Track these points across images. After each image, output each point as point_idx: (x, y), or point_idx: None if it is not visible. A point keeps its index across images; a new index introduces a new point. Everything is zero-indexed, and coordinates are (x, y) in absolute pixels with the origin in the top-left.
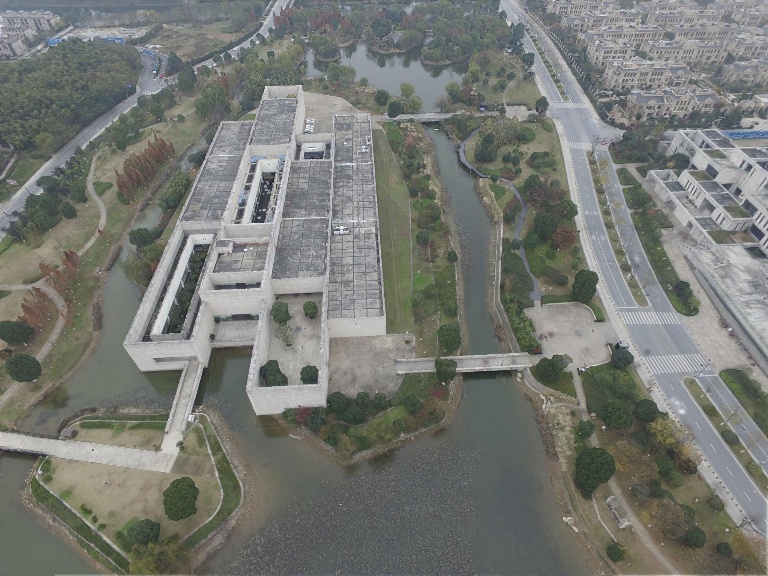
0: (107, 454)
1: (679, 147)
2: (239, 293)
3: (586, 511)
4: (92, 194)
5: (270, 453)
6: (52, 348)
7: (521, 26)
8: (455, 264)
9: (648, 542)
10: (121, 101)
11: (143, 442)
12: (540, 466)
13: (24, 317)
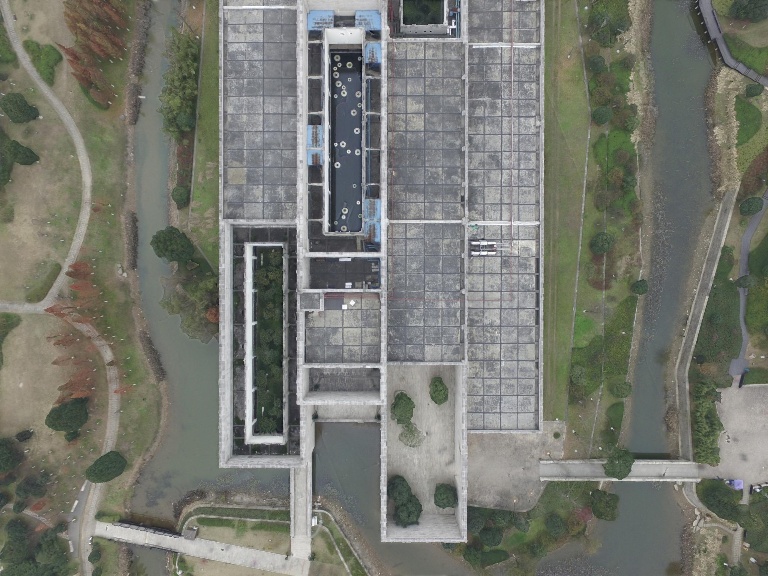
0: (238, 555)
1: None
2: None
3: None
4: (35, 79)
5: (401, 553)
6: (120, 415)
7: None
8: (638, 294)
9: None
10: None
11: (271, 546)
12: None
13: (68, 392)
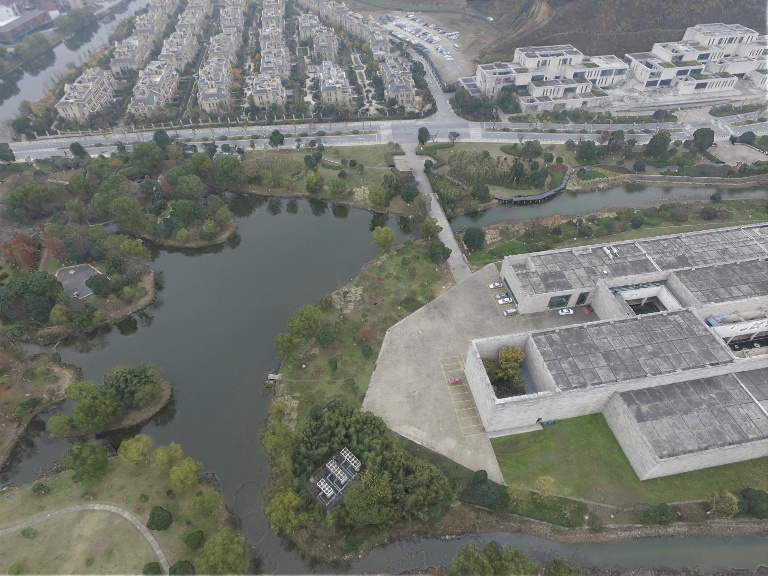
0: None
1: (497, 85)
2: None
3: None
4: None
5: None
6: None
7: (164, 132)
8: None
9: None
10: None
11: None
12: None
13: None
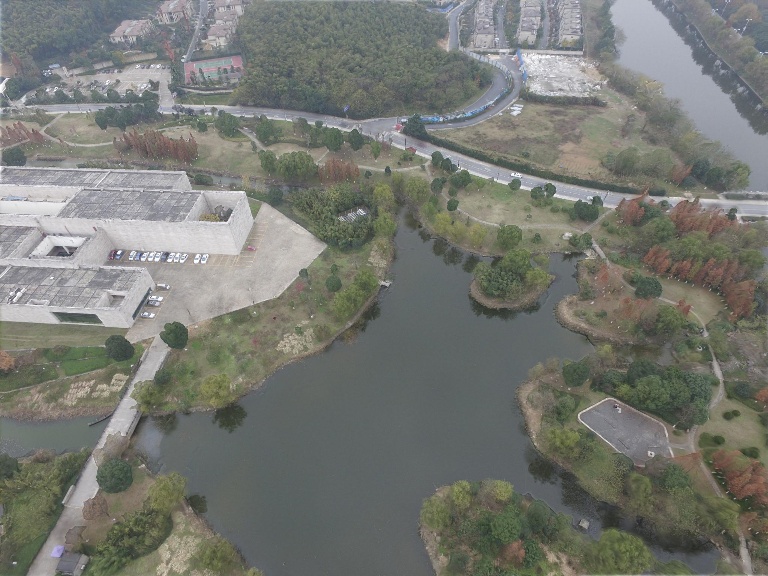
0: None
1: None
2: None
3: None
4: None
5: None
6: None
7: None
8: None
9: None
10: (337, 116)
11: None
12: None
13: None
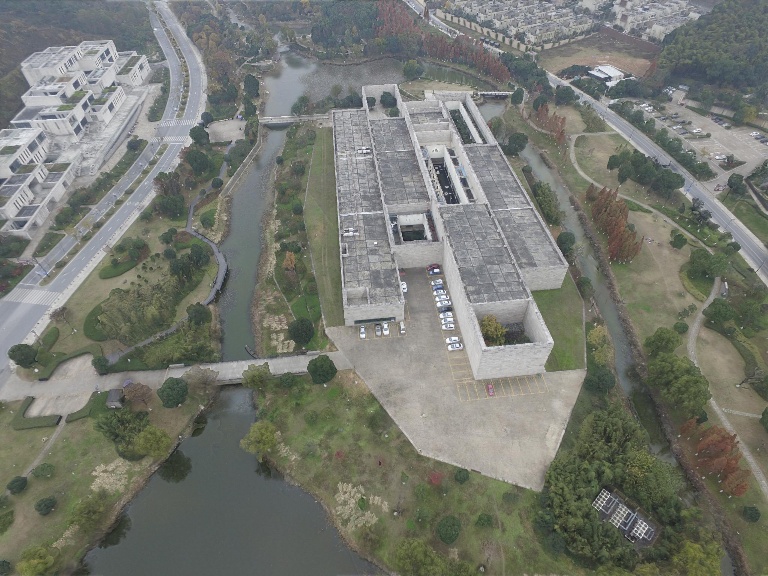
0: (454, 92)
1: None
2: (418, 103)
3: (260, 92)
4: (635, 200)
5: None
6: None
7: None
8: None
9: (243, 86)
10: None
11: None
12: (270, 101)
13: None
